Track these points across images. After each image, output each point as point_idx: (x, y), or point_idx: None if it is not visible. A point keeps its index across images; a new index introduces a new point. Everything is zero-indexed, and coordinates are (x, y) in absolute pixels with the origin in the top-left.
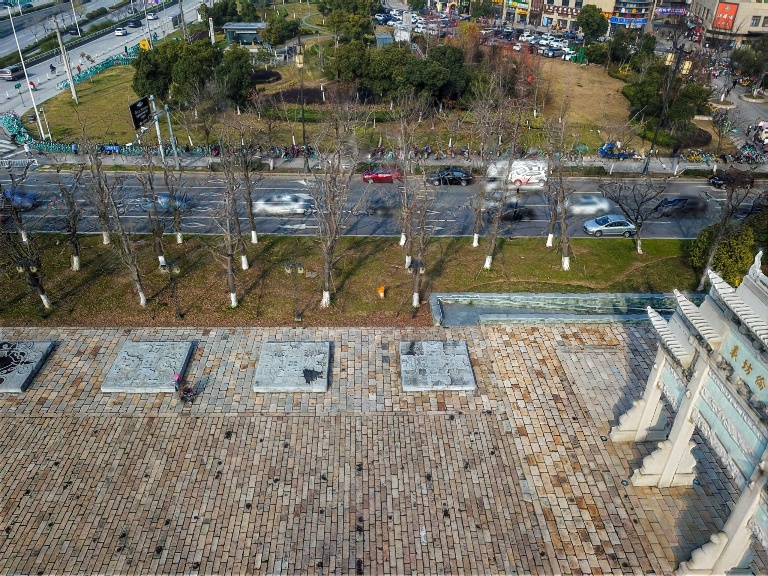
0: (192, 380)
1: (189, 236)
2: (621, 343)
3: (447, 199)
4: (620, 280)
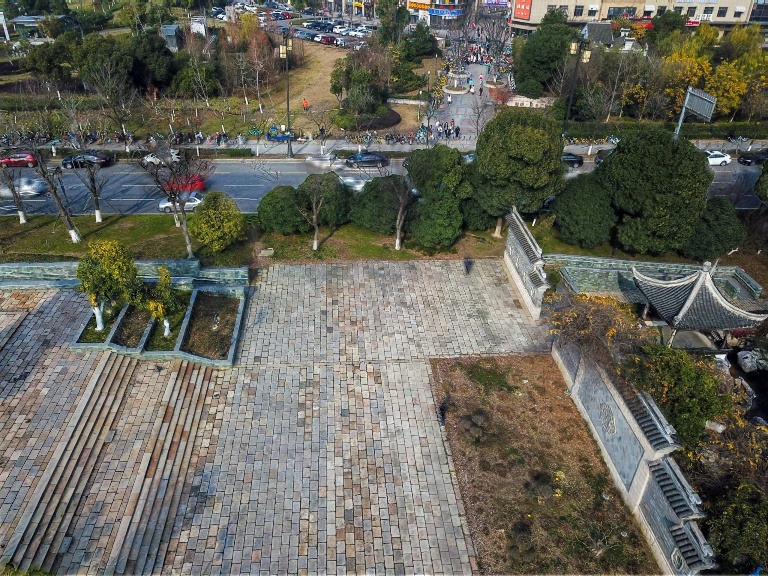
0: None
1: None
2: (35, 306)
3: None
4: None
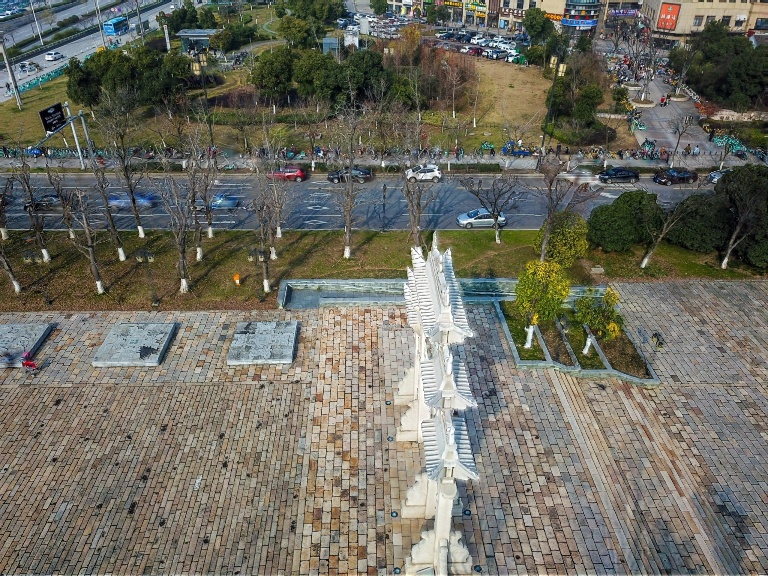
0: (41, 357)
1: None
2: None
3: None
4: (466, 267)
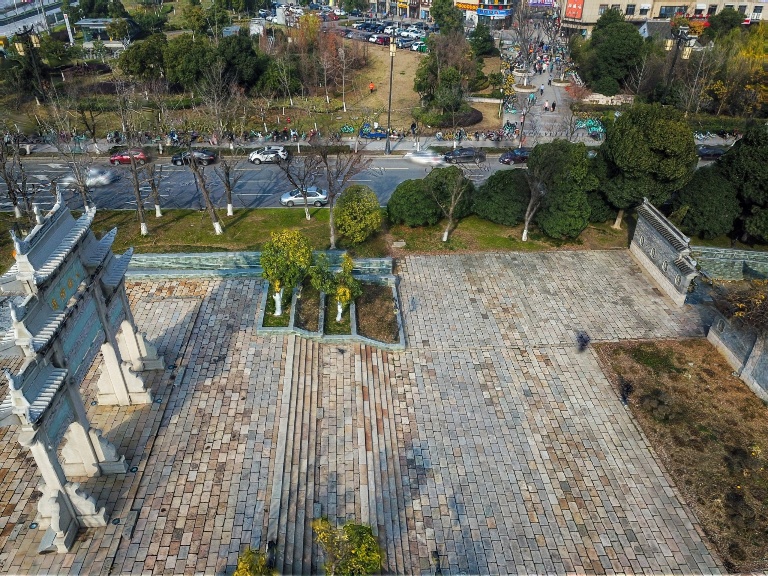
0: None
1: None
2: (206, 293)
3: (177, 177)
4: (262, 242)
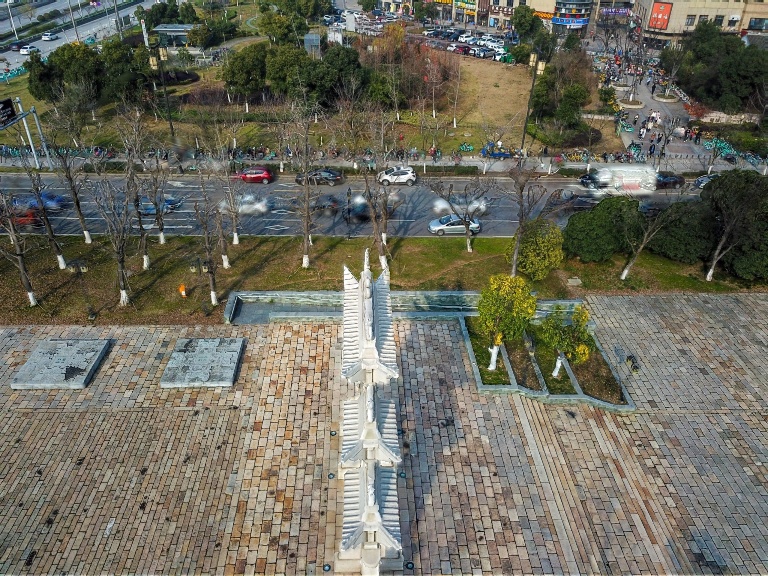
0: None
1: (27, 236)
2: (400, 340)
3: None
4: (433, 278)
